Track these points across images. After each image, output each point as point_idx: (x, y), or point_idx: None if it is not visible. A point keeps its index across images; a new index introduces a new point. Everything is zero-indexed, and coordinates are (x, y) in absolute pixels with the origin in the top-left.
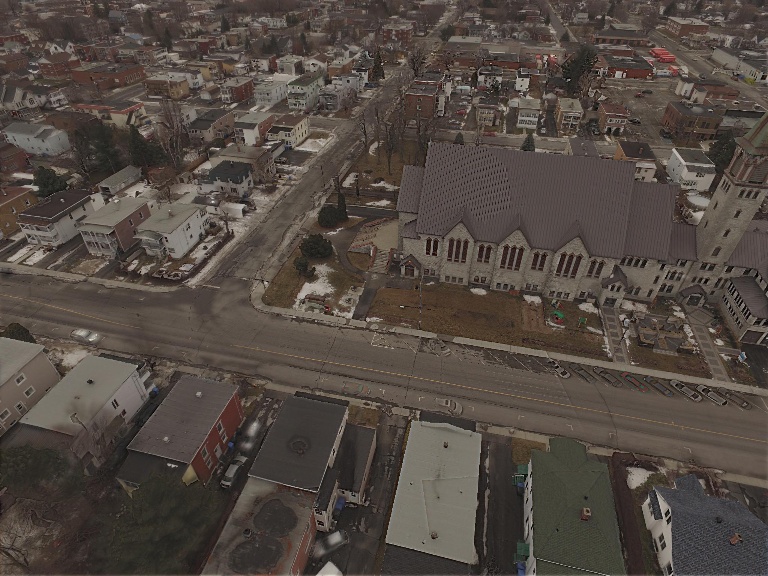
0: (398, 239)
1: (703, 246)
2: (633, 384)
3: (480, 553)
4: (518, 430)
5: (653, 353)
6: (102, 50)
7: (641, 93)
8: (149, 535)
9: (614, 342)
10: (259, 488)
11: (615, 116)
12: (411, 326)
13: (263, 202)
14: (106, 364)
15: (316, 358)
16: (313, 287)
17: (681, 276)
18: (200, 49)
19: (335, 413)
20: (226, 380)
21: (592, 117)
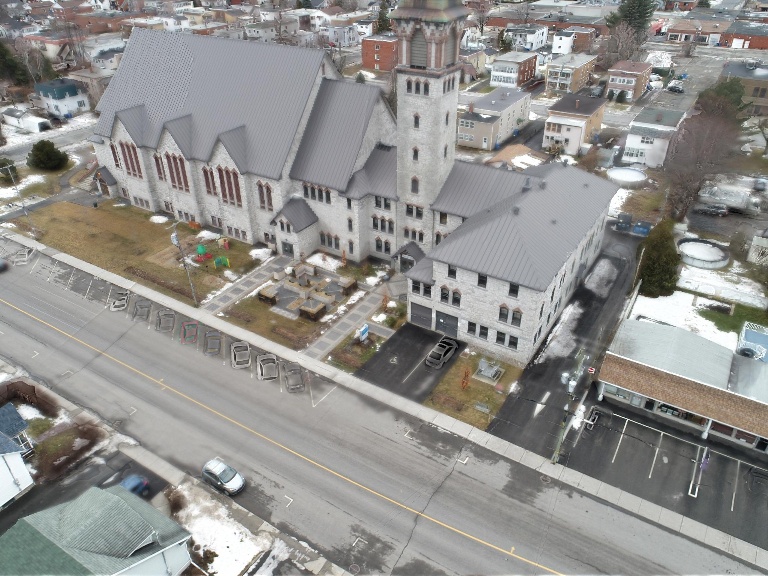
0: None
1: (397, 175)
2: (183, 333)
3: None
4: None
5: (265, 310)
6: (130, 2)
7: None
8: None
9: (234, 290)
10: None
11: (620, 74)
12: (33, 236)
13: (79, 123)
14: None
15: None
16: None
17: (393, 226)
18: (224, 3)
19: None
20: None
21: (603, 79)
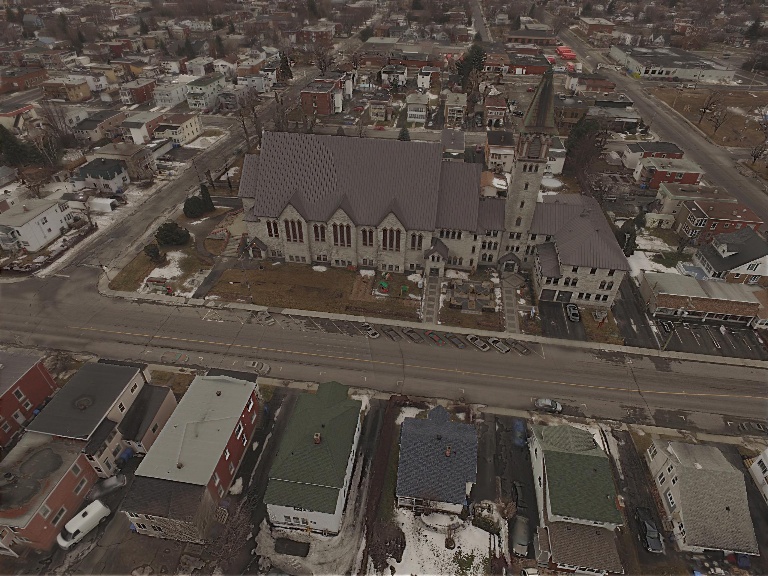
0: None
1: (507, 217)
2: (433, 340)
3: (245, 485)
4: (316, 384)
5: (460, 313)
6: (6, 54)
7: (534, 88)
8: None
9: (429, 306)
10: (34, 440)
11: (494, 109)
12: (246, 301)
13: (136, 197)
14: None
15: (146, 334)
16: (162, 272)
17: (497, 246)
18: (111, 52)
19: (126, 374)
20: (51, 357)
21: (478, 110)
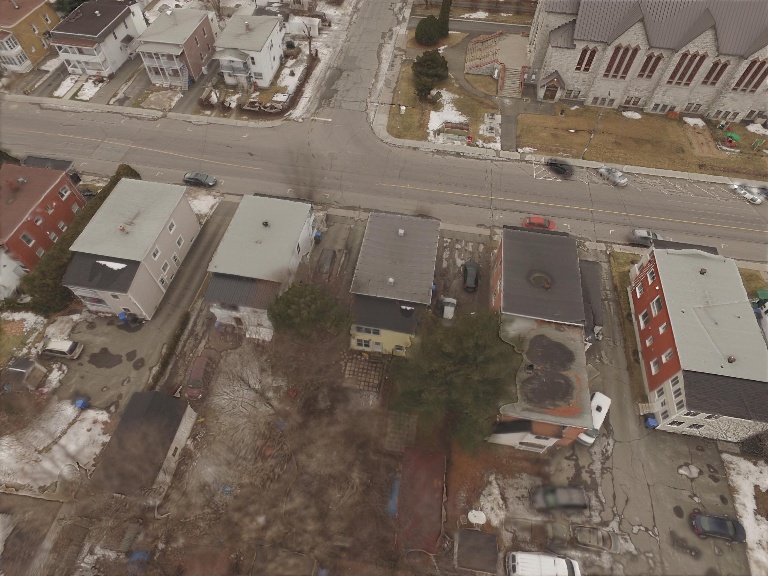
0: (536, 53)
1: None
2: None
3: None
4: None
5: None
6: None
7: None
8: (495, 372)
9: None
10: (517, 325)
11: None
12: (571, 156)
13: (335, 17)
14: (272, 204)
15: (480, 194)
16: (442, 116)
17: None
18: None
19: (565, 245)
20: None
21: None
